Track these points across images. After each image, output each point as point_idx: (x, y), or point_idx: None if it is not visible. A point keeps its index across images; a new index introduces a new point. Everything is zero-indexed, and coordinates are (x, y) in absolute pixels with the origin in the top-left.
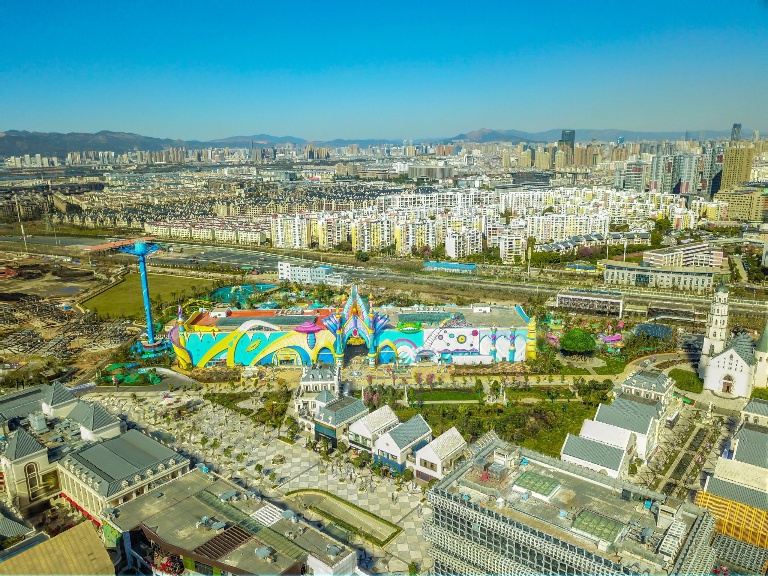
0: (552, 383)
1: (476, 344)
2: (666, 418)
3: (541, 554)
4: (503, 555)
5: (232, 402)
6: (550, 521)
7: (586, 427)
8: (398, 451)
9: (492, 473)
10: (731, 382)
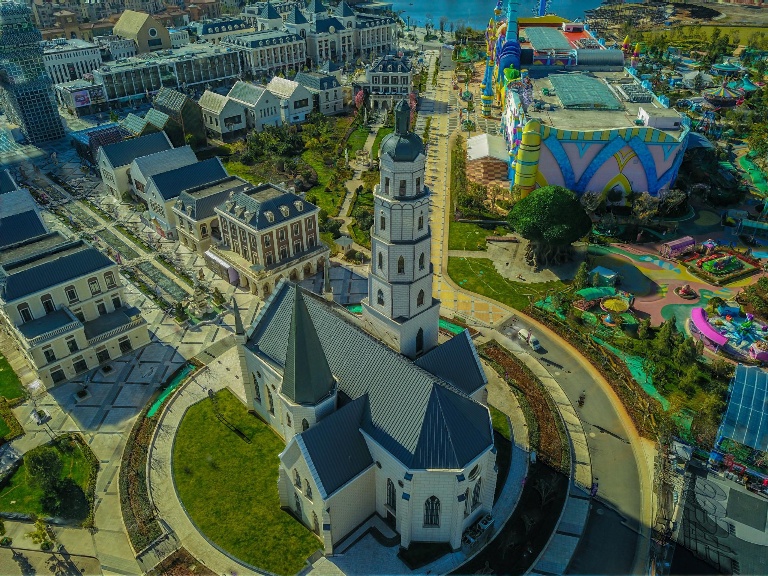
0: None
1: None
2: None
3: None
4: None
5: None
6: None
7: None
8: None
9: None
10: None
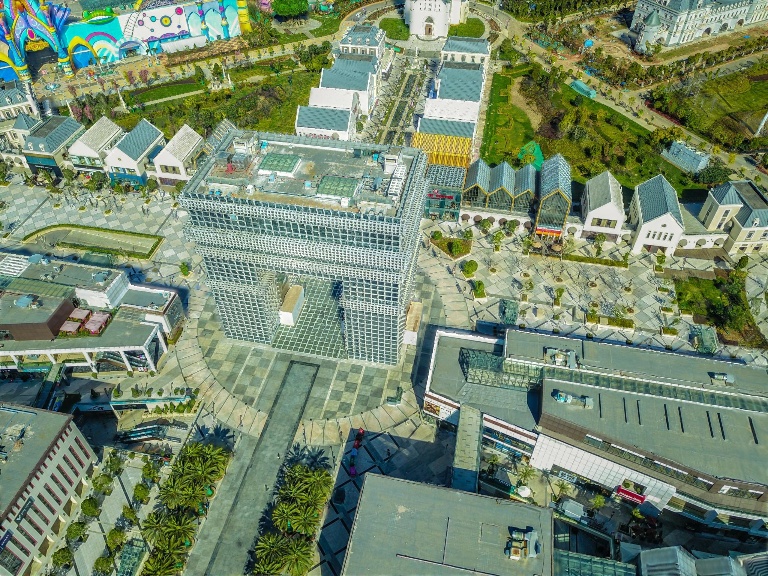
0: (273, 55)
1: (184, 24)
2: (381, 71)
3: (296, 224)
4: (263, 234)
5: None
6: (298, 194)
7: (313, 96)
8: (133, 163)
9: (236, 164)
10: (432, 24)
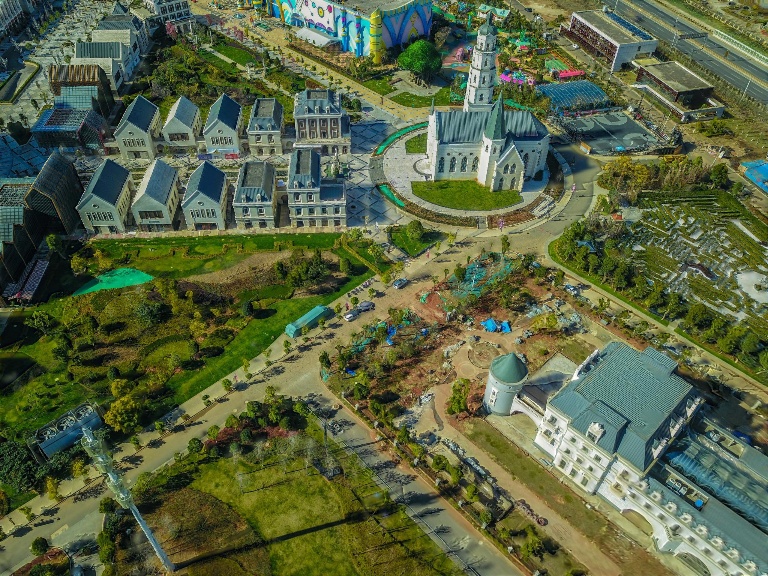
0: None
1: (331, 23)
2: None
3: None
4: None
5: (139, 3)
6: None
7: (176, 102)
8: None
9: None
10: None
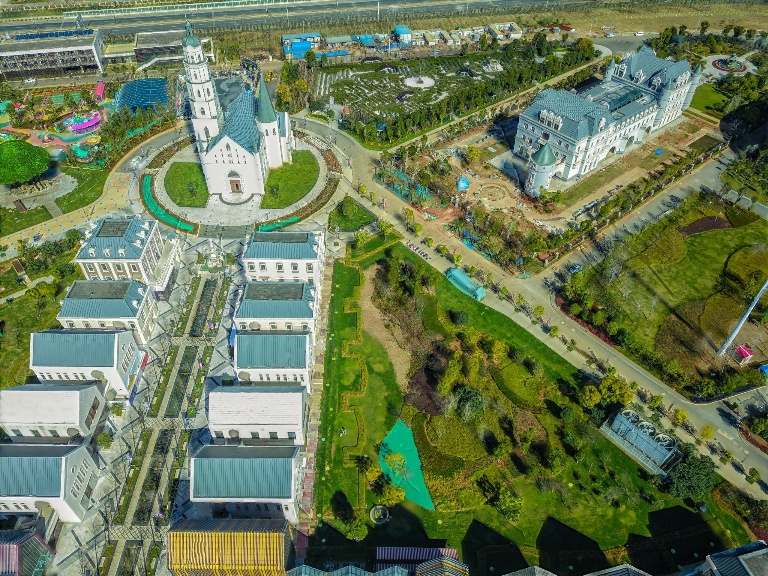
0: None
1: None
2: (155, 290)
3: None
4: None
5: None
6: None
7: (7, 406)
8: None
9: None
10: (238, 179)
